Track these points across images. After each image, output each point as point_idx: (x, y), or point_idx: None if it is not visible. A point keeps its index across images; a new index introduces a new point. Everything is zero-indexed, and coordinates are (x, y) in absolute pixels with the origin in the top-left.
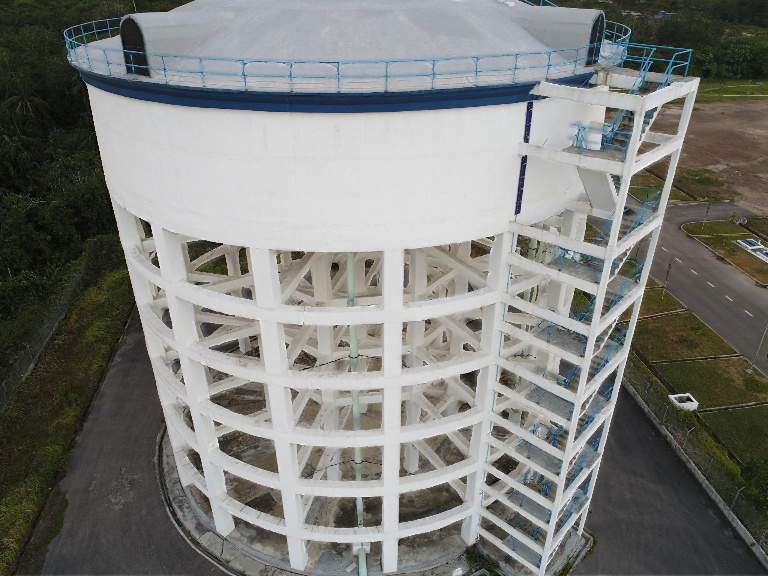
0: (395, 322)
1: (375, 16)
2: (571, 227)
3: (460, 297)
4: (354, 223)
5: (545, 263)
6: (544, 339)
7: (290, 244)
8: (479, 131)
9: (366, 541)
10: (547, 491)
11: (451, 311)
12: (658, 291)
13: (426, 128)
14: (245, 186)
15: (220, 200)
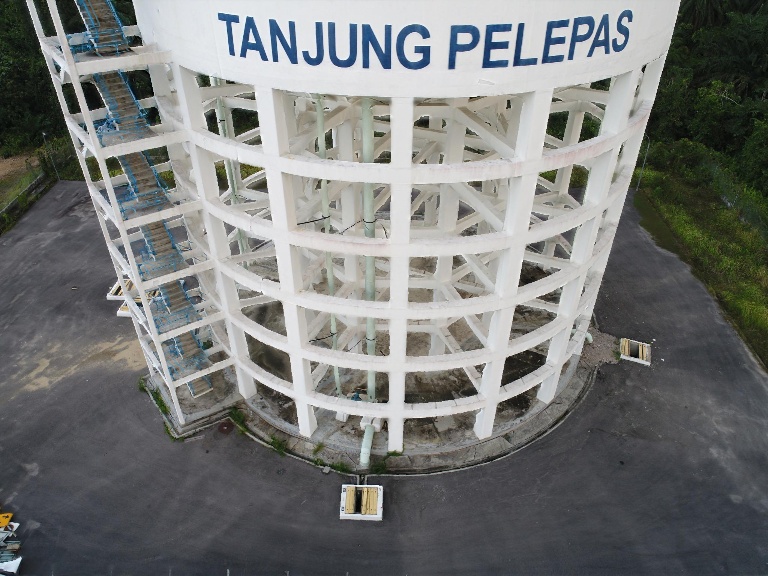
0: None
1: None
2: (177, 91)
3: None
4: None
5: None
6: None
7: None
8: None
9: None
10: (158, 311)
11: None
12: None
13: None
14: None
15: None
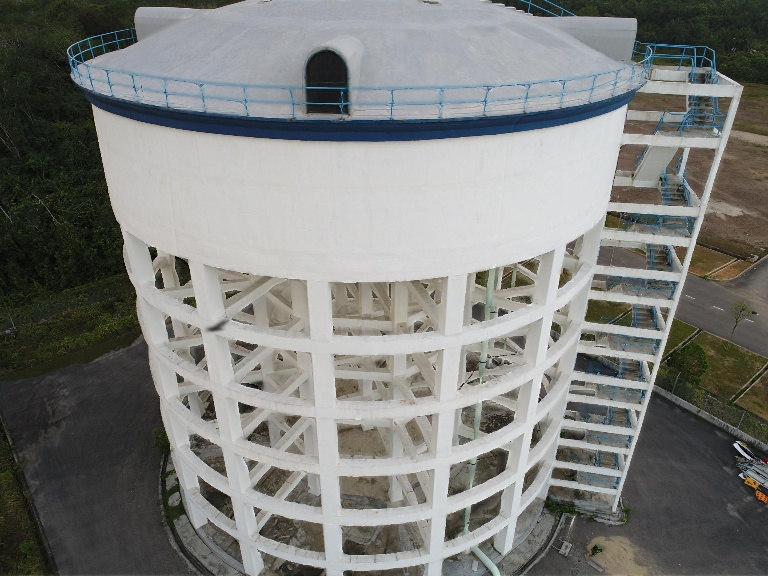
0: (550, 313)
1: (493, 33)
2: None
3: (579, 277)
4: (541, 229)
5: (636, 231)
6: (633, 295)
7: (488, 263)
8: (614, 128)
9: (497, 532)
10: (610, 424)
11: (577, 291)
12: None
13: (594, 131)
14: (454, 214)
15: (423, 235)
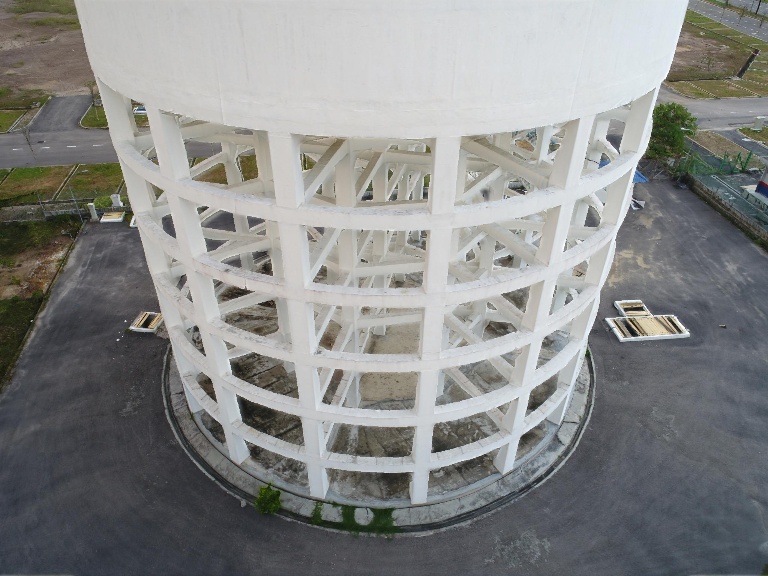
0: None
1: None
2: None
3: None
4: None
5: None
6: None
7: None
8: None
9: None
10: None
11: None
12: None
13: None
14: None
15: None
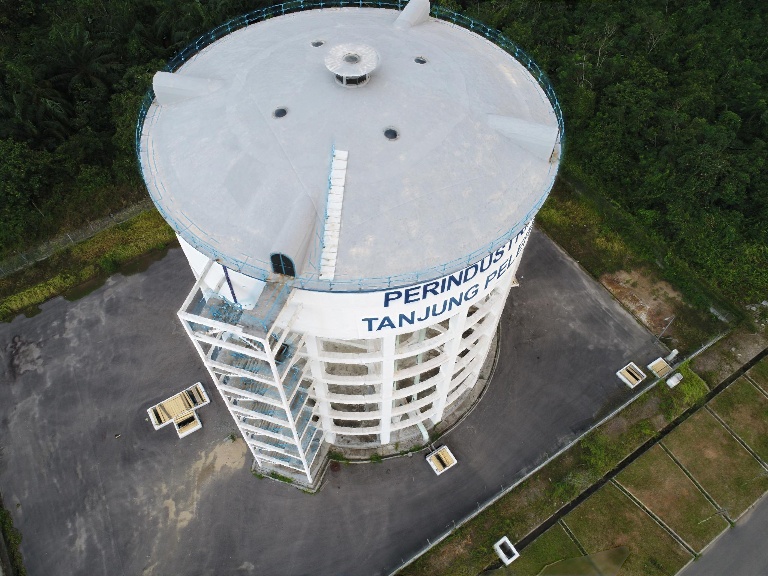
0: None
1: (229, 148)
2: None
3: None
4: None
5: None
6: None
7: None
8: None
9: None
10: None
11: None
12: (716, 518)
13: None
14: None
15: None
